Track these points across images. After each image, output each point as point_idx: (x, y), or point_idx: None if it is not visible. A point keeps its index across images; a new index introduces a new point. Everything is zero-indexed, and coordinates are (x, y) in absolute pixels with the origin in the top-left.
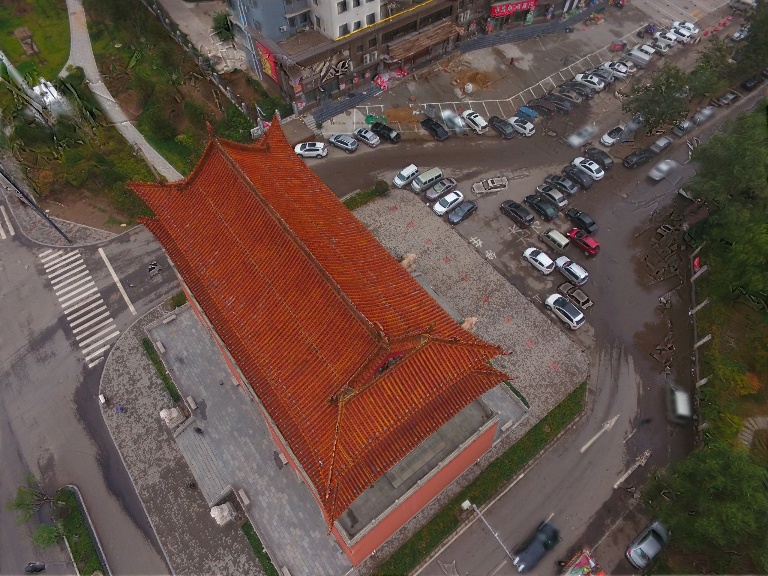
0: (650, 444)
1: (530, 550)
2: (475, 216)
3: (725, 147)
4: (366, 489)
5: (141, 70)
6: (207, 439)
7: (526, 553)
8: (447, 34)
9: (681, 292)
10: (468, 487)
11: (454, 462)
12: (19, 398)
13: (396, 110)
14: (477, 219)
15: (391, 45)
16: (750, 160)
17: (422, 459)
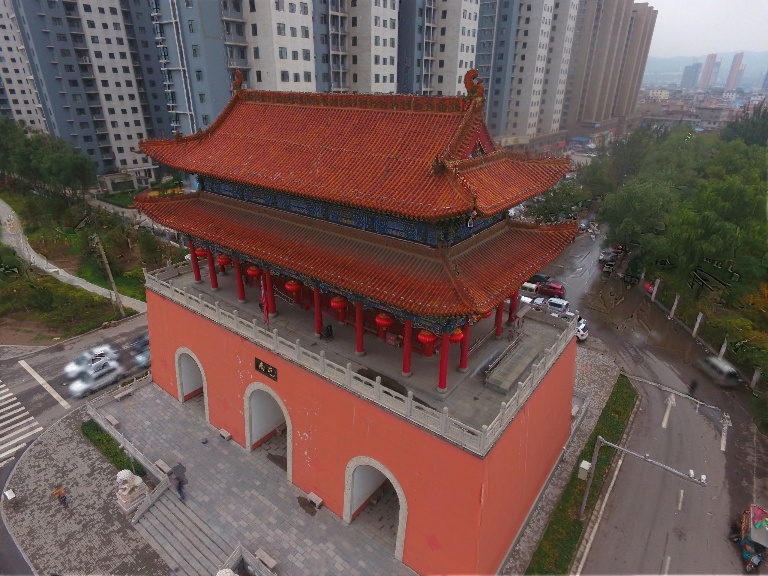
0: (722, 408)
1: (687, 535)
2: None
3: (619, 199)
4: (470, 402)
5: (89, 232)
6: (191, 505)
7: (685, 540)
8: None
9: (649, 317)
10: (569, 483)
11: (552, 389)
12: None
13: None
14: None
15: None
16: (643, 194)
17: (521, 363)
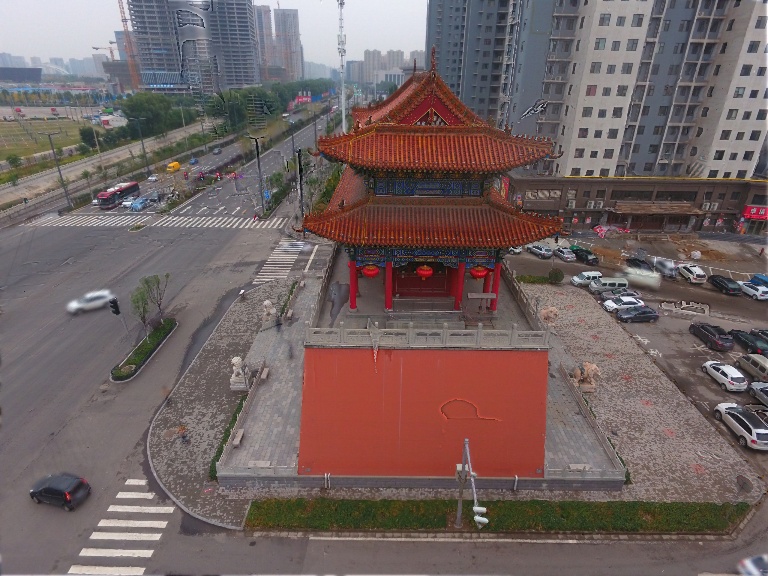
0: None
1: None
2: (652, 324)
3: None
4: (359, 327)
5: None
6: (278, 336)
7: None
8: (685, 212)
9: None
10: None
11: (470, 379)
12: (203, 279)
13: (605, 249)
14: (653, 327)
15: (620, 202)
16: None
17: None
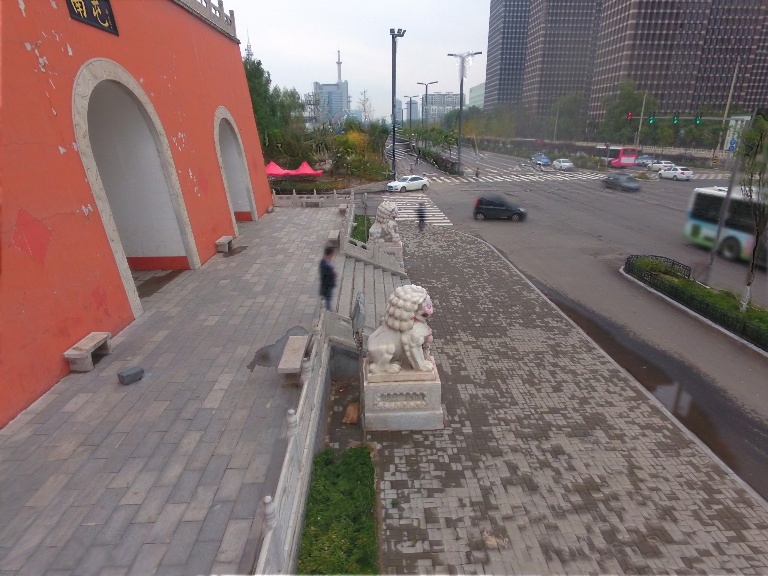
0: None
1: None
2: None
3: None
4: None
5: None
6: (333, 300)
7: None
8: None
9: None
10: None
11: None
12: None
13: None
14: None
15: None
16: None
17: None
